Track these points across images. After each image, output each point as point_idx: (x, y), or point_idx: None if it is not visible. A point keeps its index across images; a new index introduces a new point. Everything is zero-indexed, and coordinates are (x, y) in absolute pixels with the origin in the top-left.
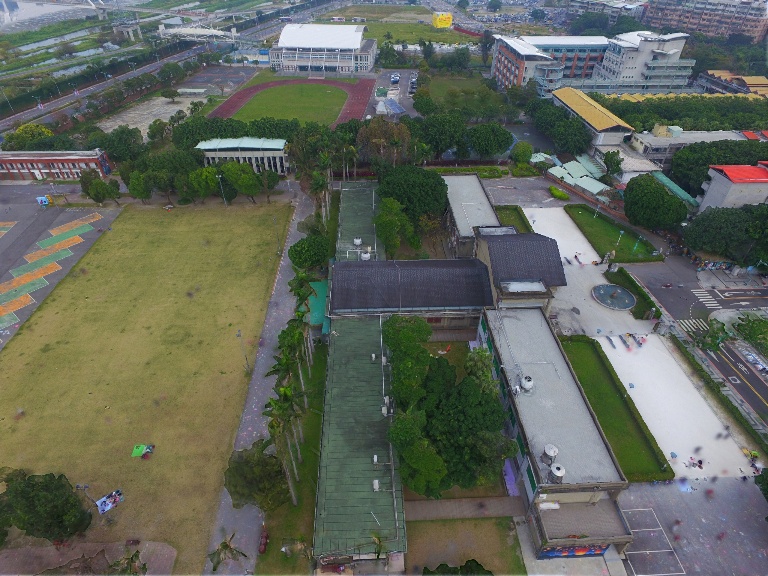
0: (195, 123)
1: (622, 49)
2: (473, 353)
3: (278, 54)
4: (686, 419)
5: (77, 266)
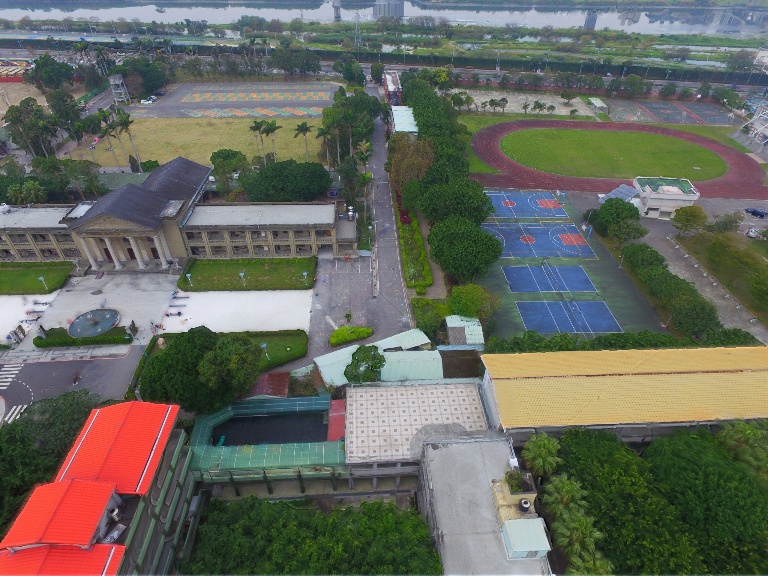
0: None
1: None
2: None
3: None
4: None
5: (271, 118)
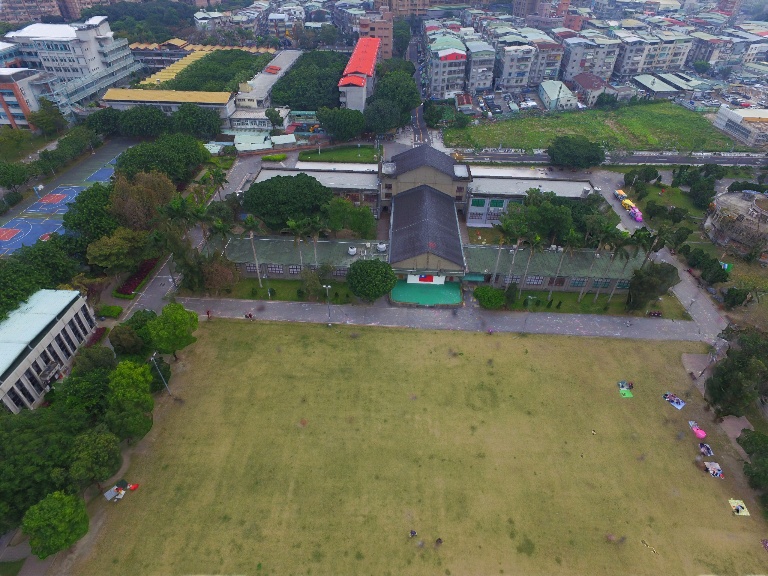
0: None
1: None
2: (532, 194)
3: None
4: None
5: None
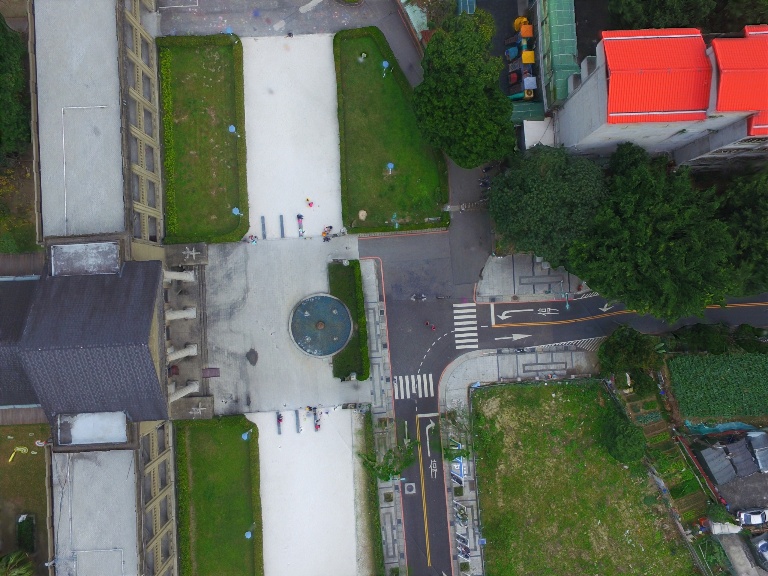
0: None
1: None
2: None
3: None
4: (318, 547)
5: None
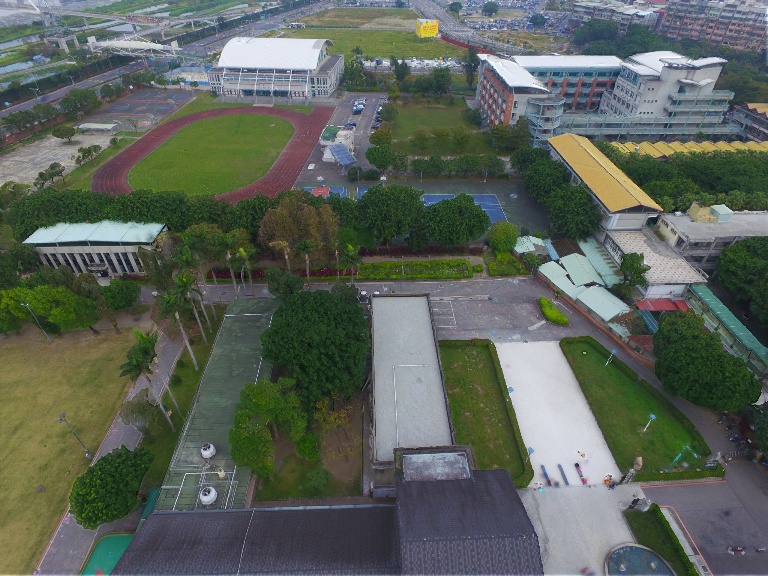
0: (34, 200)
1: (639, 77)
2: None
3: (218, 75)
4: None
5: None
